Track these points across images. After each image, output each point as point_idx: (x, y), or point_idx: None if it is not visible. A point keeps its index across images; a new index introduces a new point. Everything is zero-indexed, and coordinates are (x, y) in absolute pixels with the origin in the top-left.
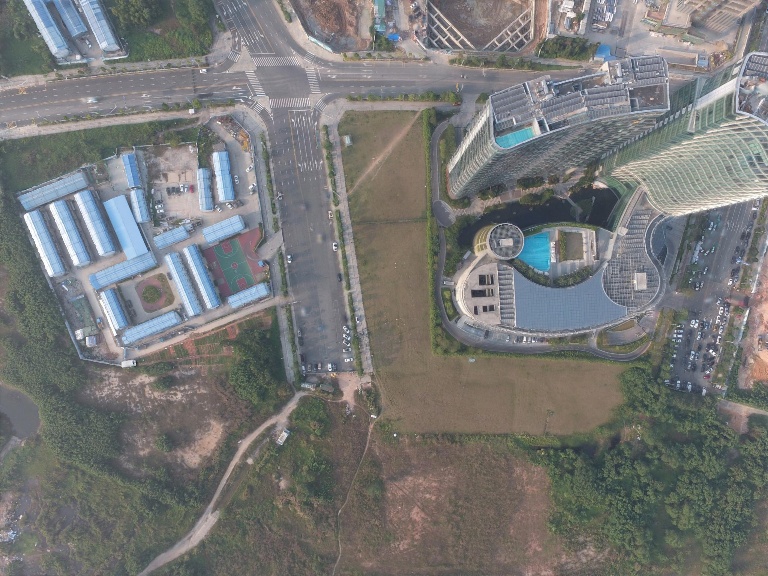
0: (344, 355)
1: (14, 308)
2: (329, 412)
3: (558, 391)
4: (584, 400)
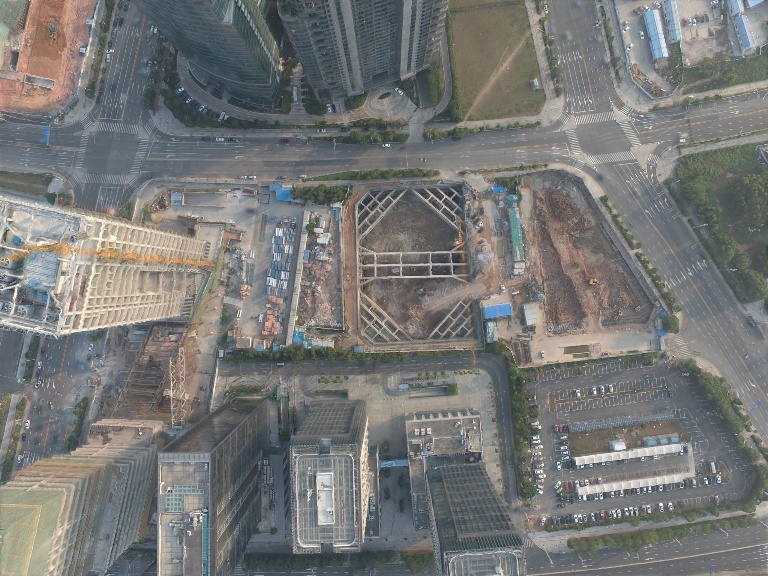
0: None
1: None
2: None
3: None
4: None
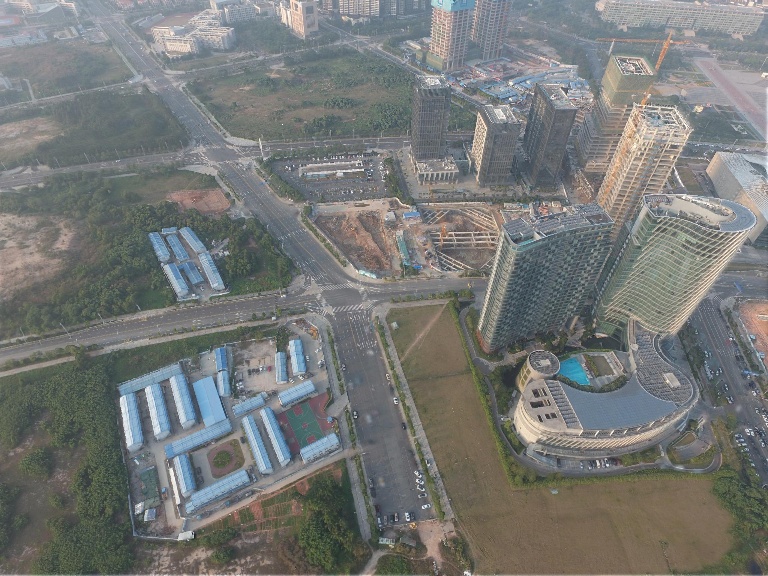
0: (420, 502)
1: (80, 483)
2: (414, 573)
3: (659, 517)
4: (692, 524)
